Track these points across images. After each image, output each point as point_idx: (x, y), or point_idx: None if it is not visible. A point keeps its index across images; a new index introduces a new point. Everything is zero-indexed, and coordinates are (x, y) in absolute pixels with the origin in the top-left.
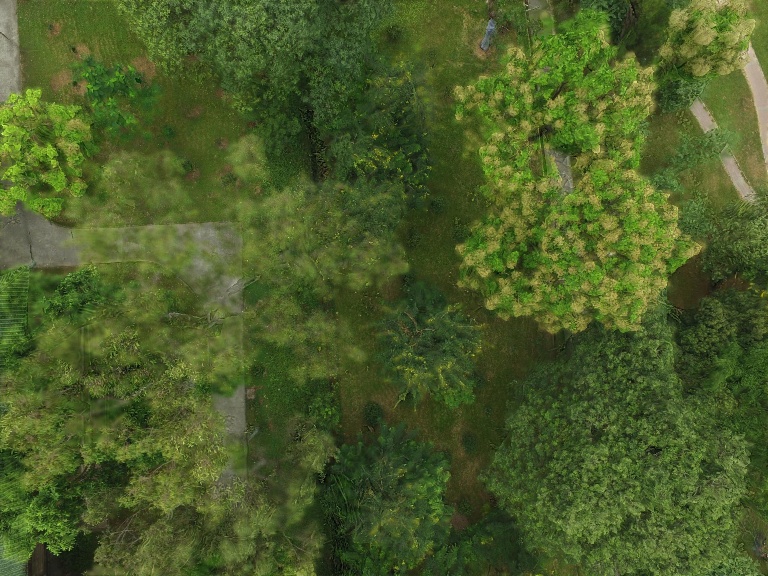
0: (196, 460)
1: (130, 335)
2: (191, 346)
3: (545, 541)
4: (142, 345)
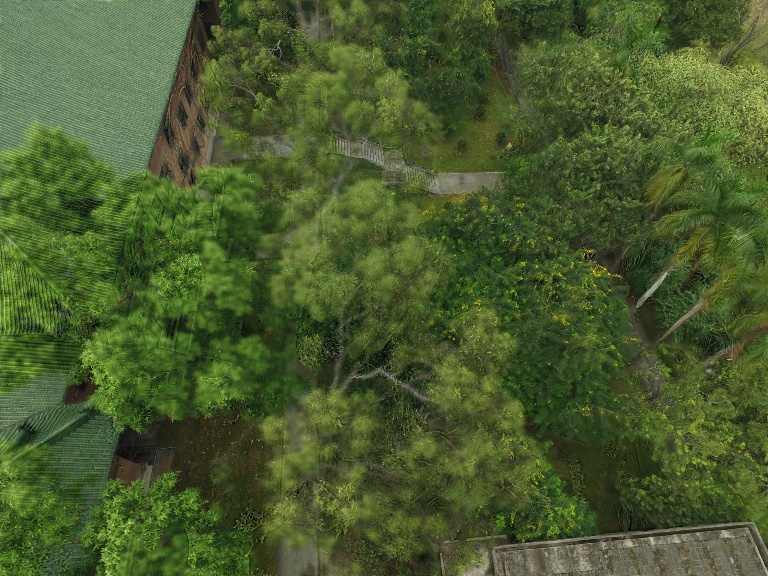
0: (291, 37)
1: (261, 4)
2: (292, 6)
3: (476, 4)
4: (266, 7)
